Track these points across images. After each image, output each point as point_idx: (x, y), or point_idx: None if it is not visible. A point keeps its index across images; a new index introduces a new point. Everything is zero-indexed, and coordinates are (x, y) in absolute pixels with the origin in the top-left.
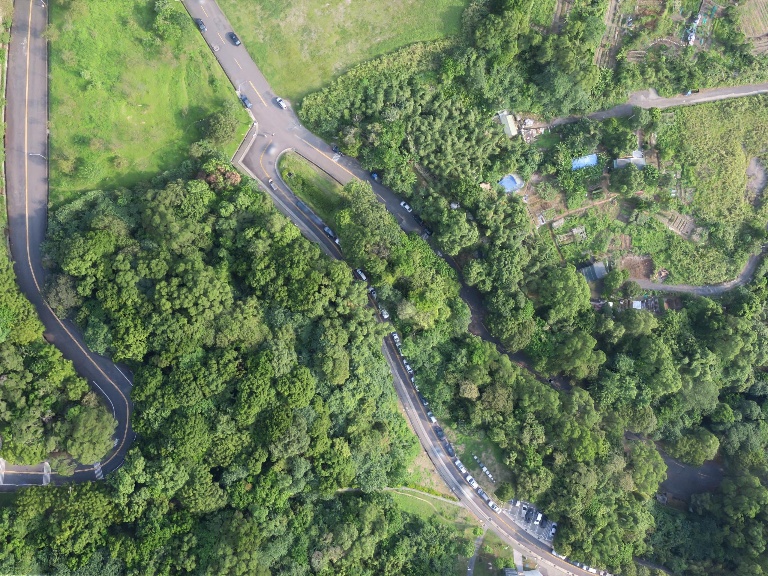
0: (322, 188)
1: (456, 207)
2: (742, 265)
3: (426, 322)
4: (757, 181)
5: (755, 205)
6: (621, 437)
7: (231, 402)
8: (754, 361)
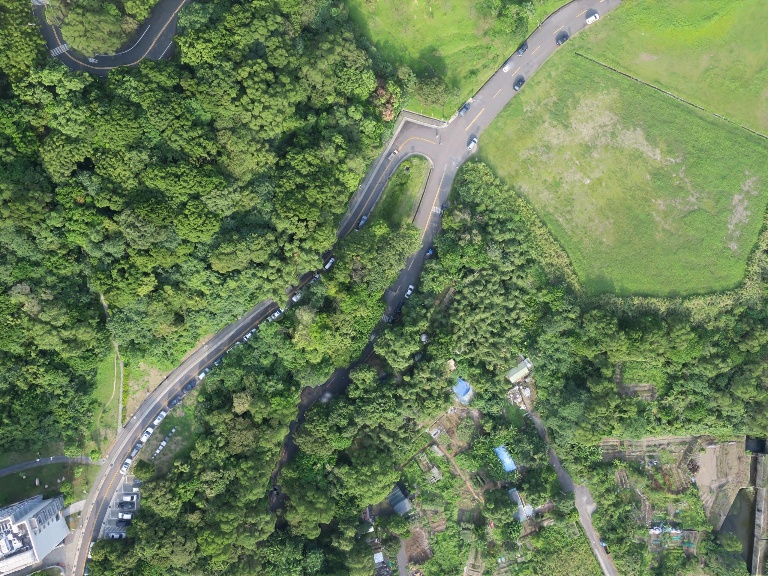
0: (403, 203)
1: (423, 340)
2: None
3: (299, 339)
4: None
5: None
6: None
7: (163, 160)
8: None
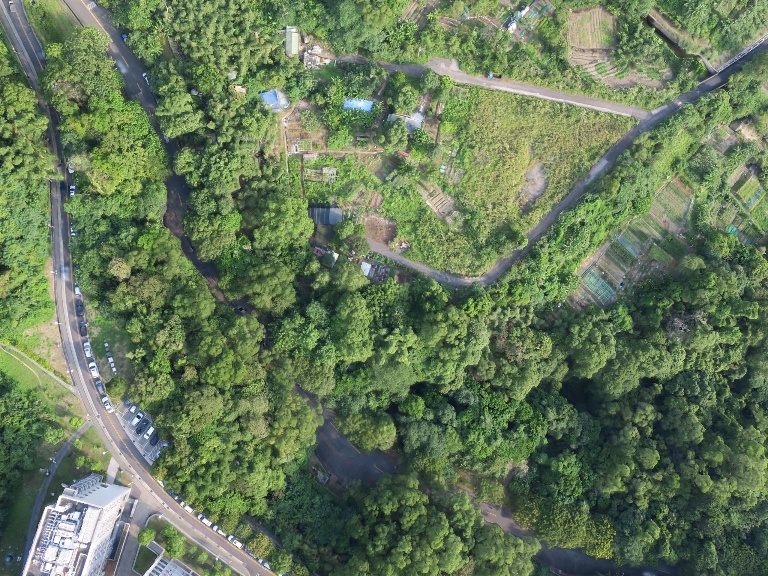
0: (62, 27)
1: None
2: (488, 263)
3: (100, 184)
4: (535, 187)
5: (524, 210)
6: (287, 388)
7: None
8: (457, 357)
